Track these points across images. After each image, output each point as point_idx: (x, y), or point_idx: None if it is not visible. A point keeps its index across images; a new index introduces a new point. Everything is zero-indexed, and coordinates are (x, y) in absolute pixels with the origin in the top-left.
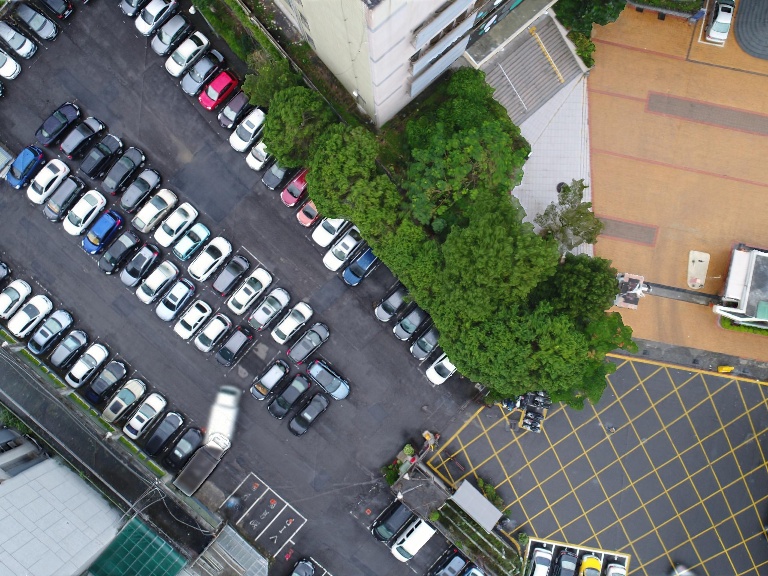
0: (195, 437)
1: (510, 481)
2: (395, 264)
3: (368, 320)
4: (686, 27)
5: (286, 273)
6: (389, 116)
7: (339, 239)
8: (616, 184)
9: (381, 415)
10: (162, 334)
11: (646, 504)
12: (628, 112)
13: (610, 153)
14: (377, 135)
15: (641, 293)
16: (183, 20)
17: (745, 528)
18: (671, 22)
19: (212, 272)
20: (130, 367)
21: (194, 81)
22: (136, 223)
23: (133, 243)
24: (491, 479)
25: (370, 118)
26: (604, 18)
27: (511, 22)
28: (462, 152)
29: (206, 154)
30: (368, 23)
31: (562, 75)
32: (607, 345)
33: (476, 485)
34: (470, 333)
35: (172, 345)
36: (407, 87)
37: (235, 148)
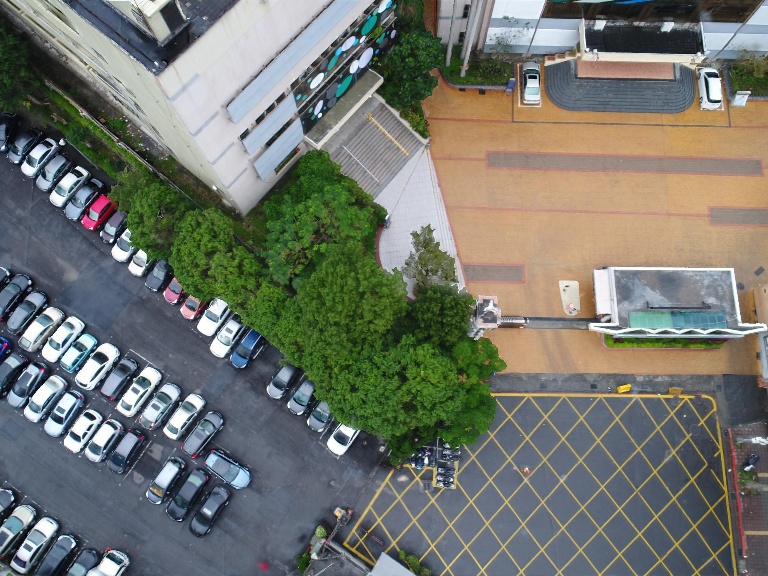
0: (89, 558)
1: (435, 549)
2: (263, 327)
3: (262, 401)
4: (505, 97)
5: (175, 368)
6: (250, 203)
7: (223, 326)
8: (476, 233)
9: (287, 499)
10: (52, 452)
11: (583, 548)
12: (472, 171)
13: (464, 208)
14: (244, 223)
15: (493, 308)
16: (64, 159)
17: (693, 556)
18: (491, 95)
19: (101, 379)
20: (19, 494)
21: (76, 207)
22: (22, 343)
23: (20, 363)
24: (414, 550)
25: (235, 209)
26: (420, 93)
27: (341, 108)
28: (308, 214)
29: (91, 270)
30: (164, 92)
31: (406, 149)
32: (477, 367)
33: (398, 558)
34: (339, 377)
35: (63, 462)
36: (254, 170)
37: (117, 259)
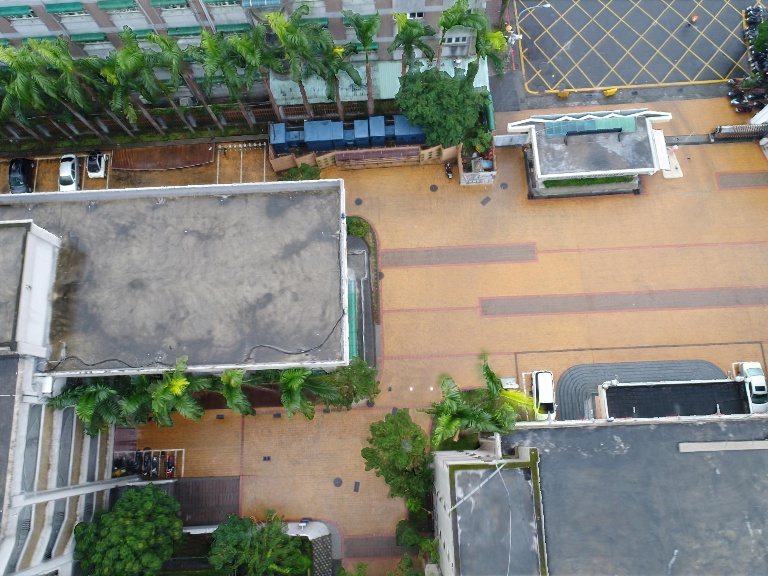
0: None
1: None
2: None
3: None
4: None
5: None
6: None
7: None
8: None
9: None
10: None
11: None
12: None
13: None
14: None
15: None
16: None
17: None
18: None
19: None
20: None
21: None
22: None
23: None
24: None
25: None
26: None
27: None
28: None
29: None
30: None
31: None
32: None
33: None
34: None
35: None
36: None
37: None
